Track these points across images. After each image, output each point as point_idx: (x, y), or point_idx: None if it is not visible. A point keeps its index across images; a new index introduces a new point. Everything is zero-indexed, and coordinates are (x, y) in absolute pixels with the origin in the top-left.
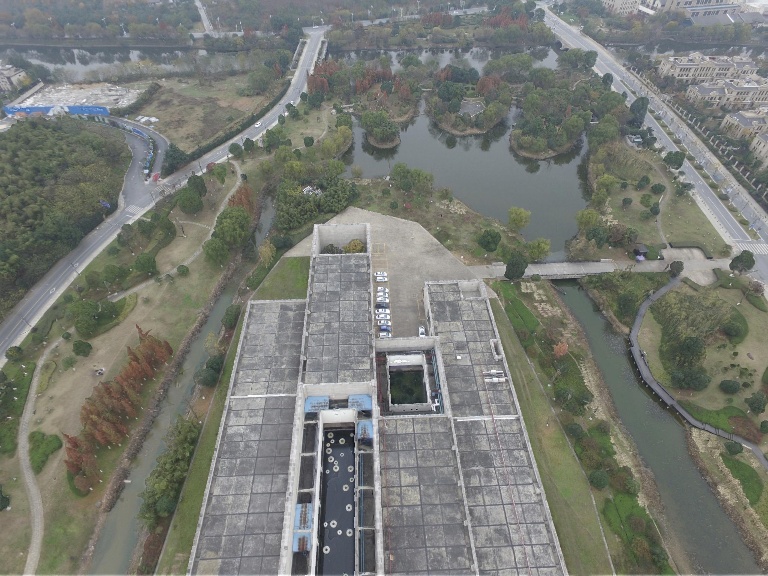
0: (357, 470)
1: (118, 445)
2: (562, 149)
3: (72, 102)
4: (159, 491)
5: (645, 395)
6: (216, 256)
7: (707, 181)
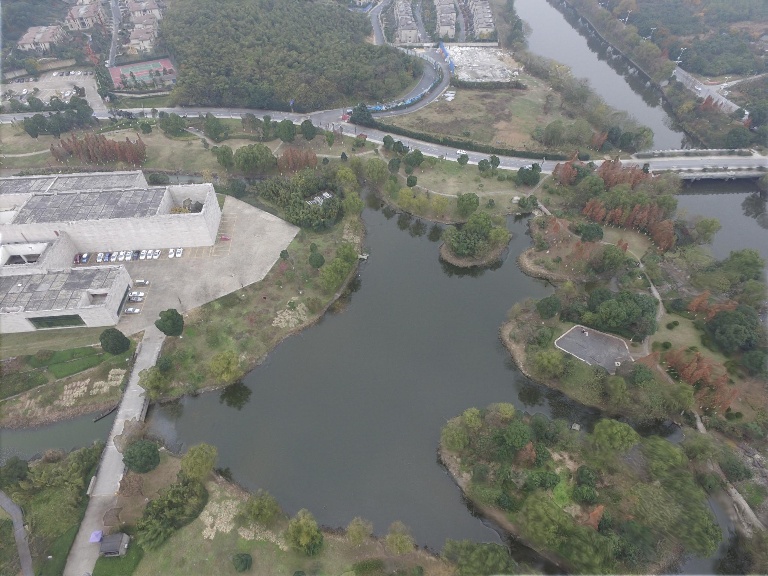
0: None
1: None
2: (475, 498)
3: (472, 62)
4: None
5: None
6: (218, 157)
7: None
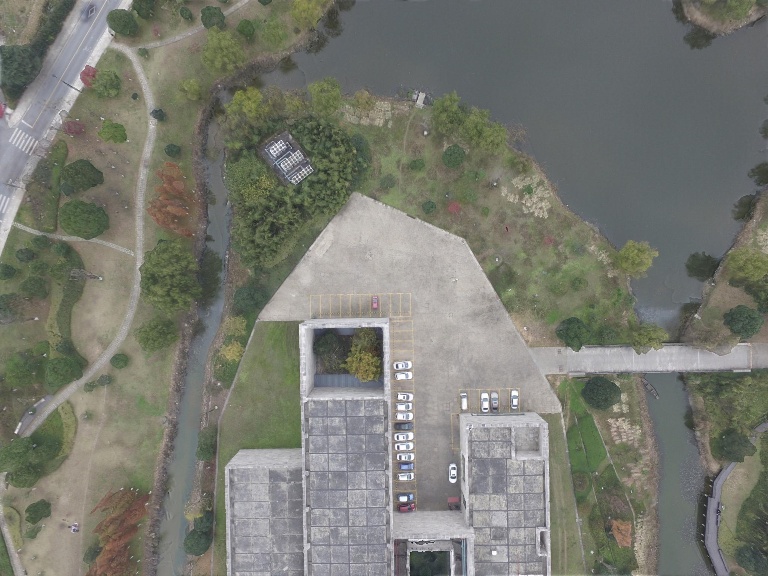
0: None
1: None
2: None
3: None
4: None
5: (697, 546)
6: (160, 346)
7: None
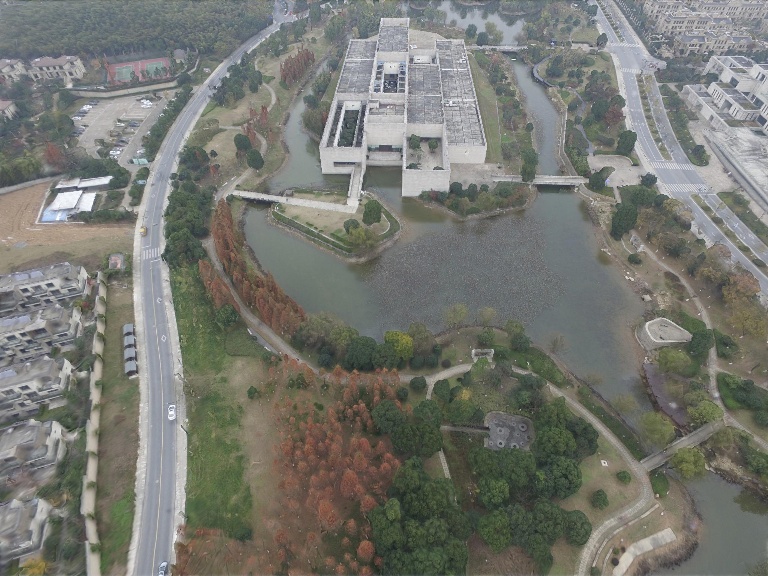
0: None
1: (297, 81)
2: (529, 10)
3: None
4: (320, 82)
5: None
6: (331, 34)
7: (610, 23)
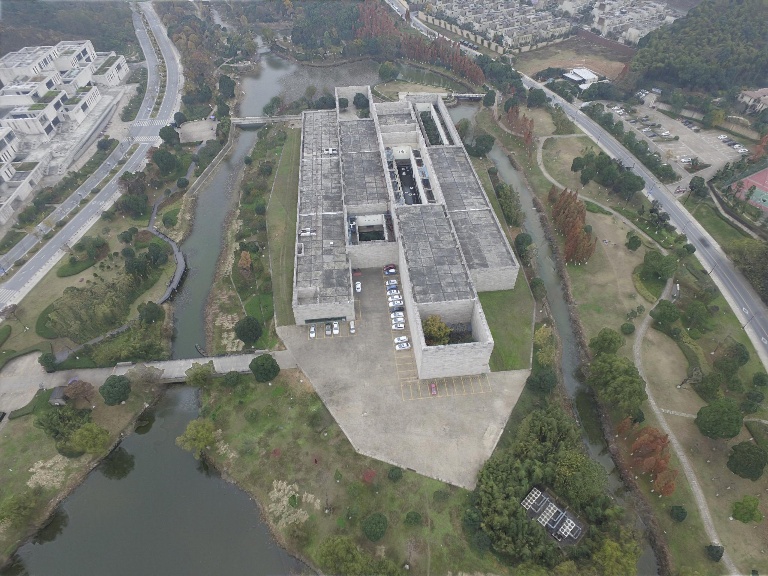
0: (400, 184)
1: None
2: None
3: None
4: None
5: None
6: None
7: None
